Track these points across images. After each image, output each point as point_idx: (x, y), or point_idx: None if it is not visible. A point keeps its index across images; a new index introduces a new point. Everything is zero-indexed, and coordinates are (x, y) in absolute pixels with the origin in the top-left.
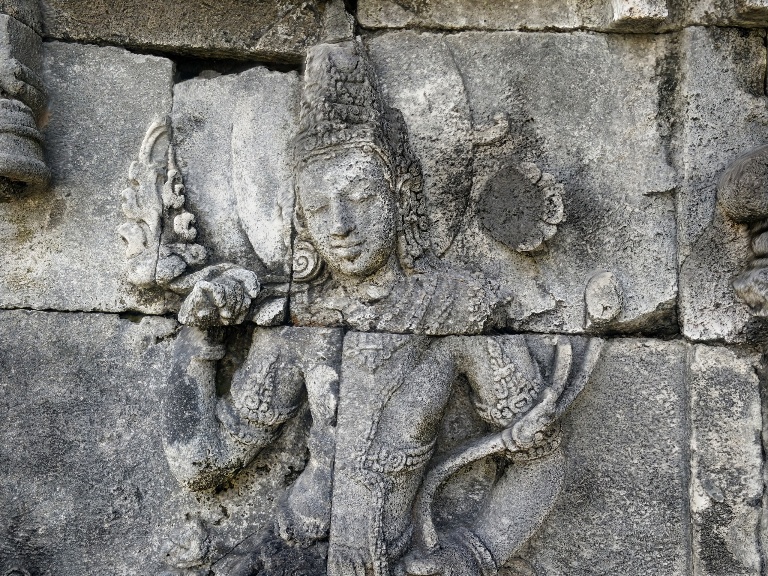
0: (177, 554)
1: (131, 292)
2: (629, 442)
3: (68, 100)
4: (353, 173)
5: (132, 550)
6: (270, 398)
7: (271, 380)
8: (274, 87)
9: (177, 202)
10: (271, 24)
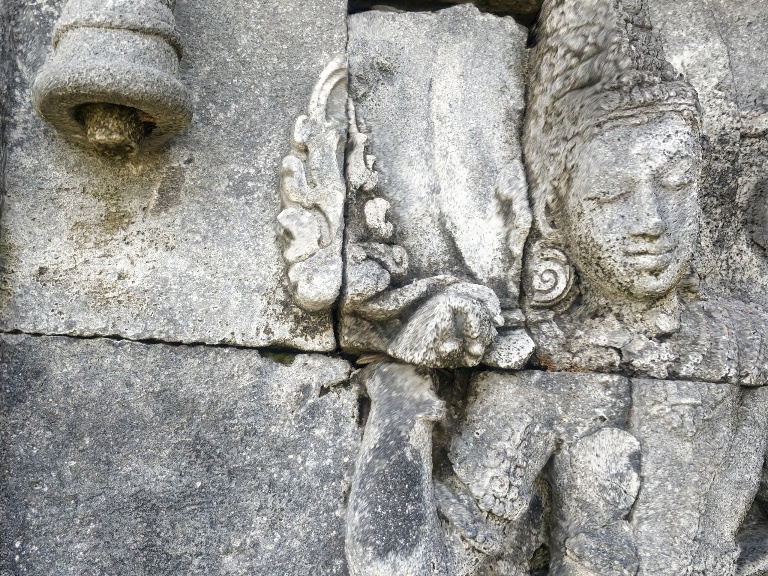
0: None
1: (282, 315)
2: None
3: (196, 16)
4: (674, 146)
5: None
6: (521, 479)
7: (525, 451)
8: (487, 34)
9: (370, 180)
10: None
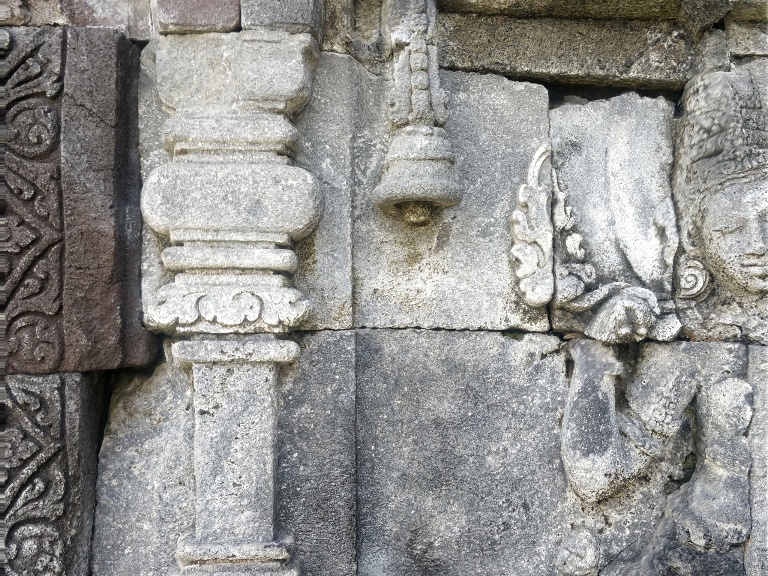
0: (574, 562)
1: (515, 310)
2: None
3: (454, 126)
4: None
5: (521, 559)
6: None
7: (676, 393)
8: (645, 112)
9: (569, 224)
10: (641, 52)
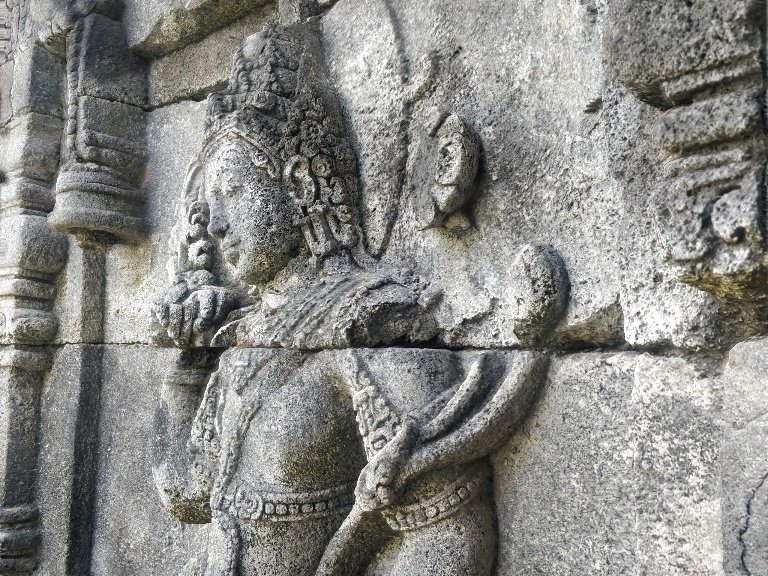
0: None
1: None
2: (591, 530)
3: (160, 157)
4: (218, 166)
5: None
6: (212, 425)
7: (210, 405)
8: None
9: (192, 231)
10: None
